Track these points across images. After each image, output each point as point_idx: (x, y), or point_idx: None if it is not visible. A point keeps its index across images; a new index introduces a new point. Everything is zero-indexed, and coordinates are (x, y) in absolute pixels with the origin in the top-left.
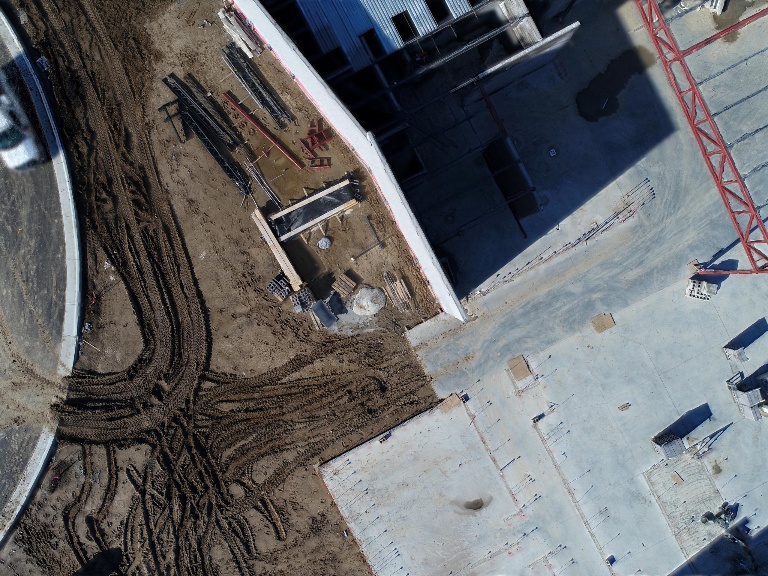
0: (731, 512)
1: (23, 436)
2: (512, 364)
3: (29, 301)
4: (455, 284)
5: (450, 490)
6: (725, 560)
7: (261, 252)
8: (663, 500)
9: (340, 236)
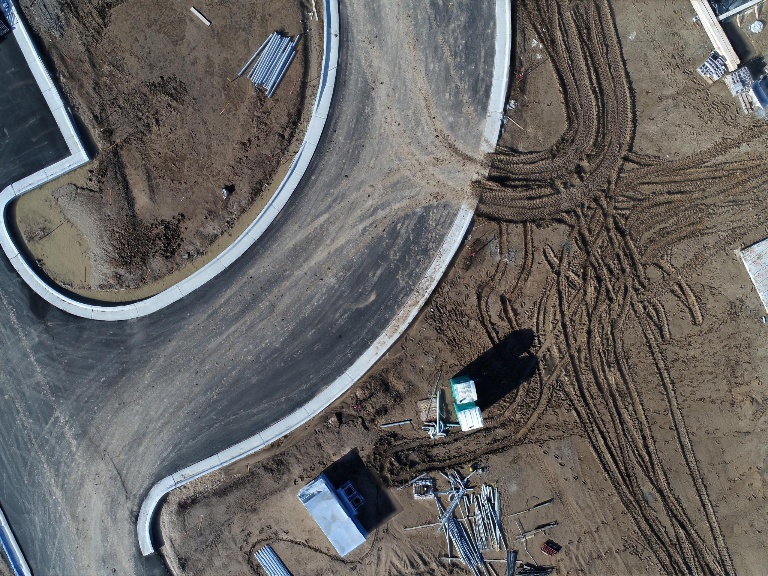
0: None
1: (441, 212)
2: None
3: (456, 76)
4: None
5: None
6: None
7: (693, 34)
8: None
9: None
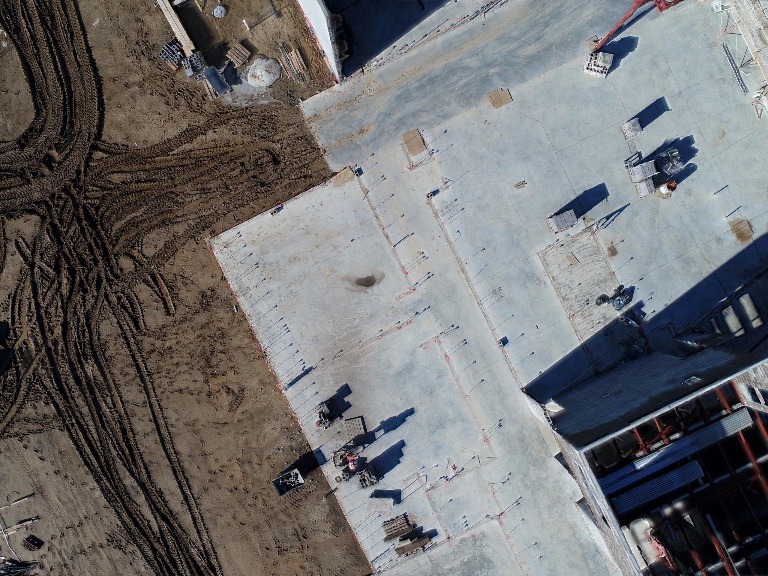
0: (627, 295)
1: None
2: (407, 138)
3: None
4: (351, 55)
5: (342, 266)
6: (620, 344)
7: (155, 20)
8: (558, 281)
9: (236, 5)
